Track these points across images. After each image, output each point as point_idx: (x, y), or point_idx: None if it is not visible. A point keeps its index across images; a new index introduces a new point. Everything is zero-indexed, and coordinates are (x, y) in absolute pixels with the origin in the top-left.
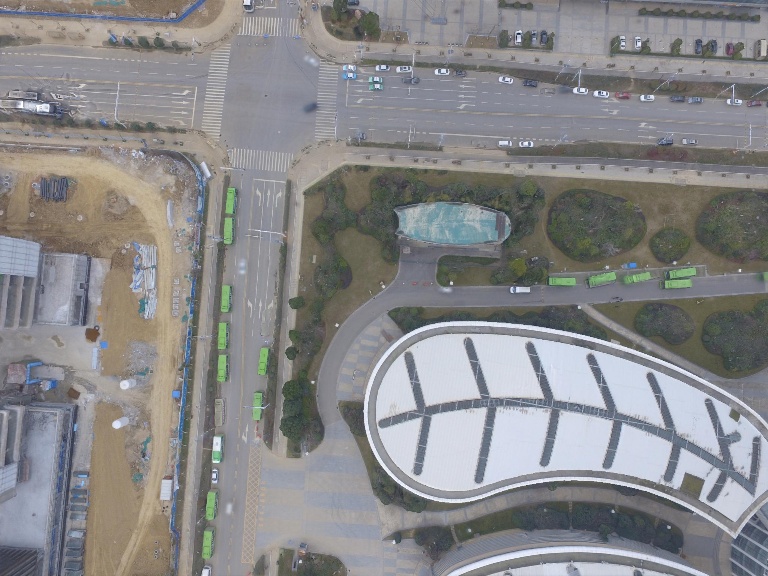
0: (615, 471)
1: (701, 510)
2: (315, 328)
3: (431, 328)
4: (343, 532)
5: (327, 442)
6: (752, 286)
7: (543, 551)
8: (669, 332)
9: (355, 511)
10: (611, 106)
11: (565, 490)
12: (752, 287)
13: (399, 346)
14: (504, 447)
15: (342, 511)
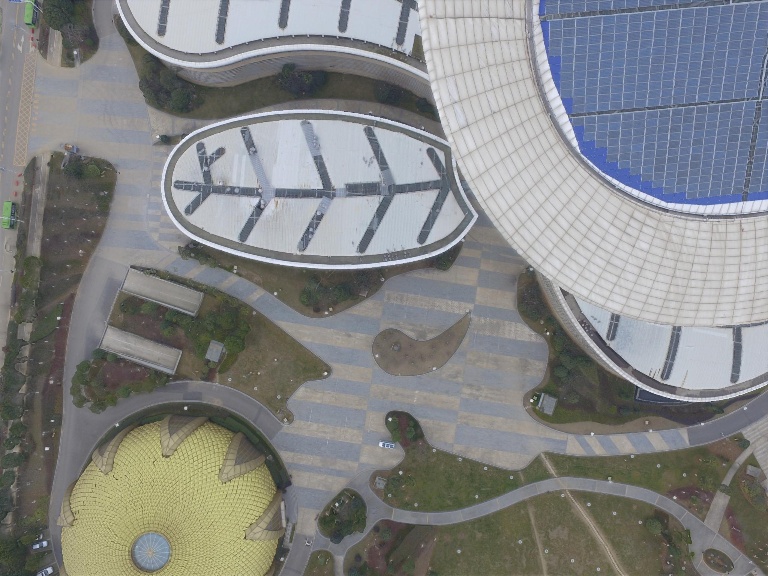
0: (351, 35)
1: None
2: None
3: None
4: (114, 137)
5: (101, 53)
6: None
7: (282, 111)
8: None
9: (127, 118)
10: None
11: (331, 102)
12: None
13: None
14: (242, 5)
15: (114, 118)
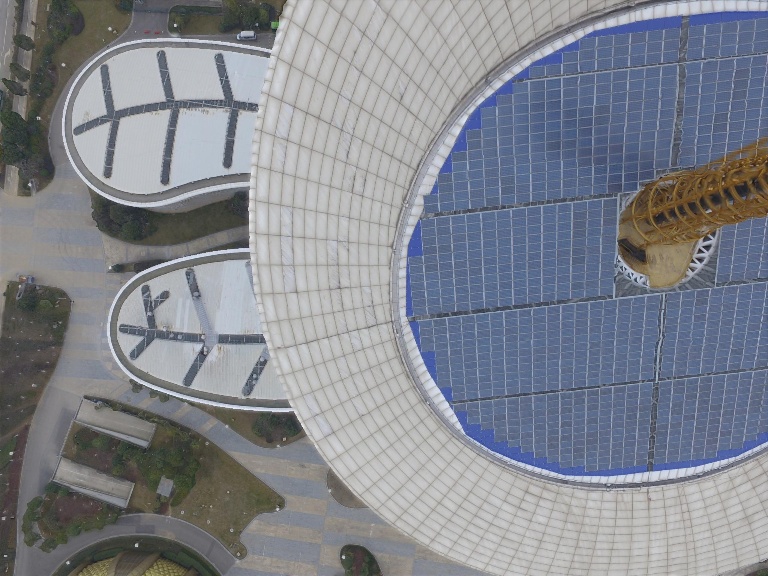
0: None
1: None
2: (45, 70)
3: (129, 44)
4: (69, 266)
5: (57, 181)
6: None
7: (227, 251)
8: None
9: (81, 246)
10: None
11: None
12: None
13: (98, 61)
14: (186, 147)
15: (69, 246)
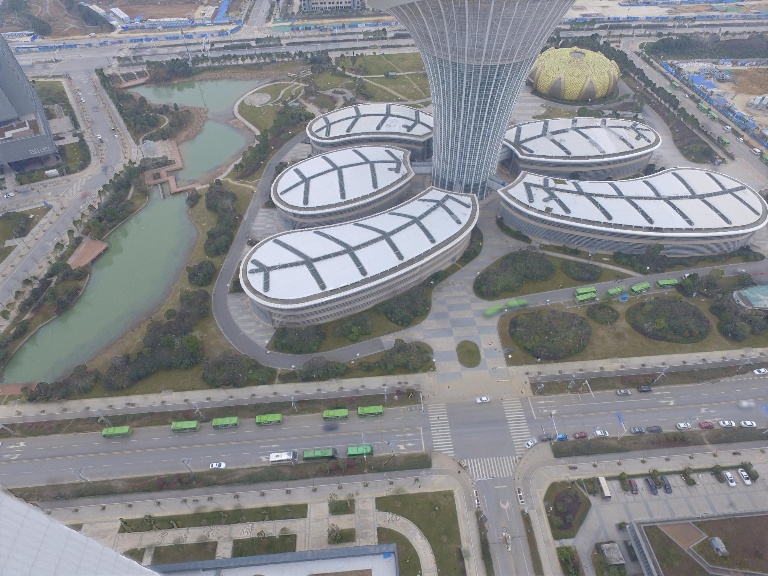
0: None
1: (546, 177)
2: None
3: (755, 228)
4: None
5: None
6: (526, 300)
7: (619, 157)
8: (578, 264)
9: None
10: (710, 415)
11: None
12: (526, 300)
13: (766, 218)
14: None
15: None
